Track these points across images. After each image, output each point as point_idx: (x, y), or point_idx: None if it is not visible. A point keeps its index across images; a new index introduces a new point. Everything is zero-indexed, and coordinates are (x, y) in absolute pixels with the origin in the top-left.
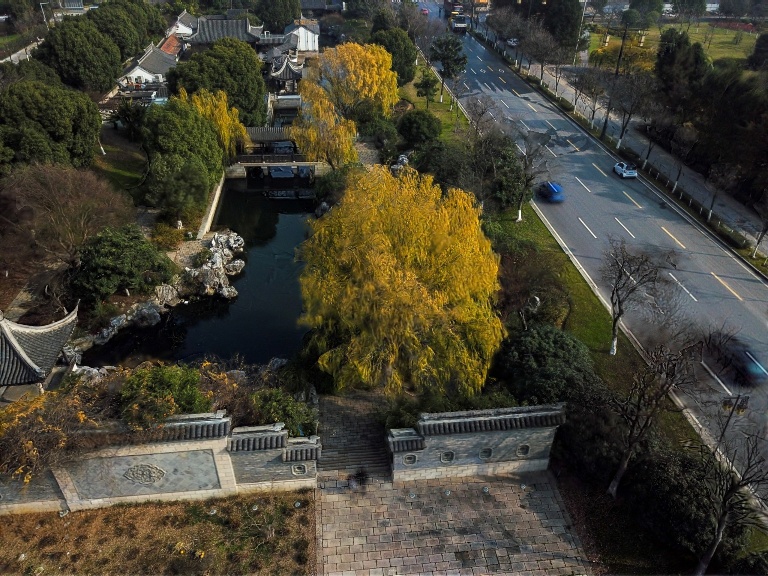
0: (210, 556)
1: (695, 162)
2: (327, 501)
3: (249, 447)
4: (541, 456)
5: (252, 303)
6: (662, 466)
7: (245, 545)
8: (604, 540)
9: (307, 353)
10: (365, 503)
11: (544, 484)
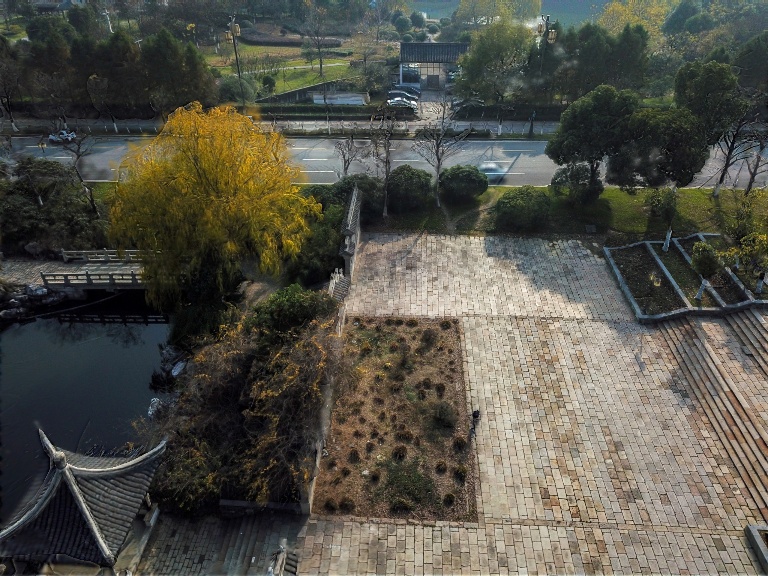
0: (402, 344)
1: (87, 113)
2: (357, 311)
3: (342, 294)
4: (359, 224)
5: (13, 394)
6: (396, 179)
7: (384, 346)
8: (410, 226)
9: (221, 290)
10: (364, 296)
11: (370, 236)
